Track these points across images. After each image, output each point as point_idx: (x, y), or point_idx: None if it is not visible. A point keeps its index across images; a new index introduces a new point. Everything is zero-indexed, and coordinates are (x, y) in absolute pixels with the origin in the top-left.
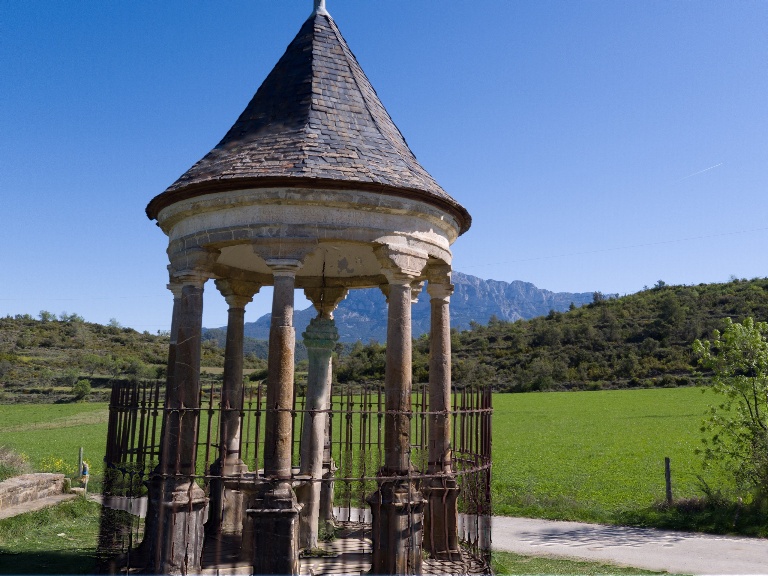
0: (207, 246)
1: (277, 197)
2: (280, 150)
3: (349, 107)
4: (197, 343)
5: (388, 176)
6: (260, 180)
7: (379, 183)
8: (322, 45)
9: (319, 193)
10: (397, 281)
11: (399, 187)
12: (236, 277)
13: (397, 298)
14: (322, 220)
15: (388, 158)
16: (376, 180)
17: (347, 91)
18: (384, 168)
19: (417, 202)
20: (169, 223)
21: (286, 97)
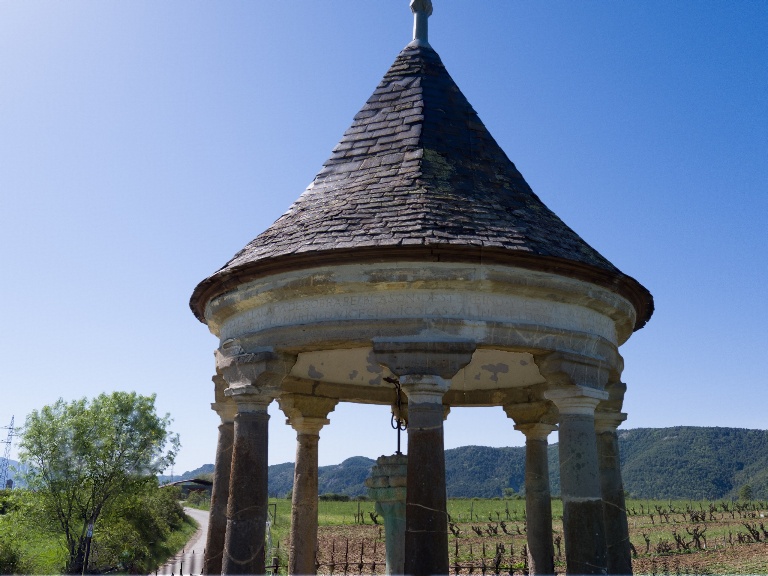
0: None
1: None
2: None
3: None
4: None
5: None
6: None
7: None
8: None
9: None
10: None
11: None
12: None
13: None
14: None
15: None
16: None
17: None
18: None
19: None
20: (625, 334)
21: None
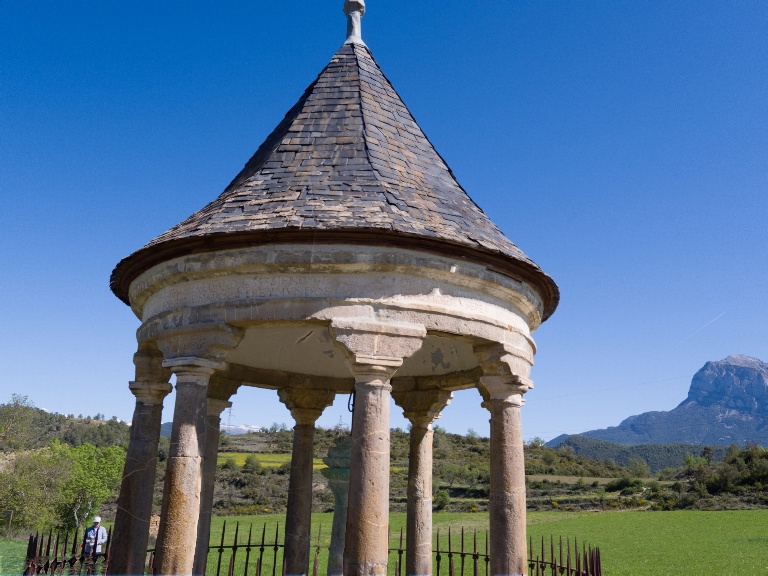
0: (147, 349)
1: (177, 271)
2: (206, 209)
3: (336, 139)
4: (142, 479)
5: (326, 216)
6: (158, 252)
7: (297, 227)
8: (332, 76)
9: (222, 257)
10: (359, 377)
11: (338, 229)
12: (299, 385)
13: (359, 404)
14: (234, 295)
15: (355, 193)
16: (292, 224)
17: (342, 121)
18: (331, 206)
19: (384, 249)
20: None
21: (268, 147)
